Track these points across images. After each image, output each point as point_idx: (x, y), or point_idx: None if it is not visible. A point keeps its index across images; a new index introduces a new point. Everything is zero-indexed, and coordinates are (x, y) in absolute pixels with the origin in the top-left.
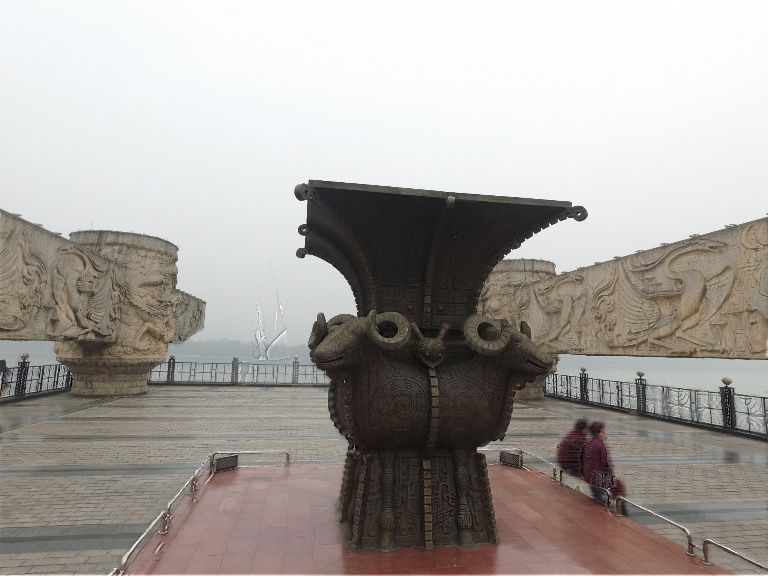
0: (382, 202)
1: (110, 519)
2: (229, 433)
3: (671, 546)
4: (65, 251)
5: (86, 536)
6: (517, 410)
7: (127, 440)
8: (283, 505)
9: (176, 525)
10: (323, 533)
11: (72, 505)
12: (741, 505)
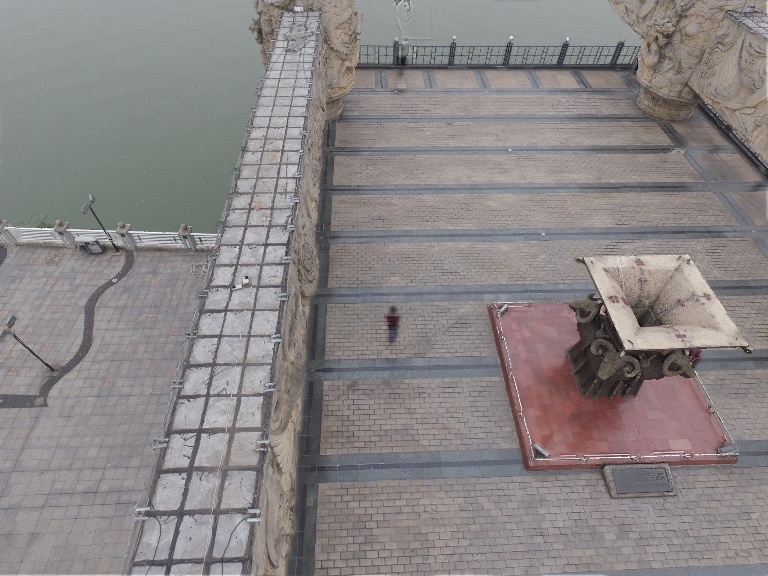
0: None
1: (474, 352)
2: (463, 227)
3: (703, 401)
4: None
5: (475, 366)
6: (661, 158)
7: (412, 242)
8: (545, 356)
9: (512, 371)
10: (569, 382)
11: (449, 337)
12: (757, 354)
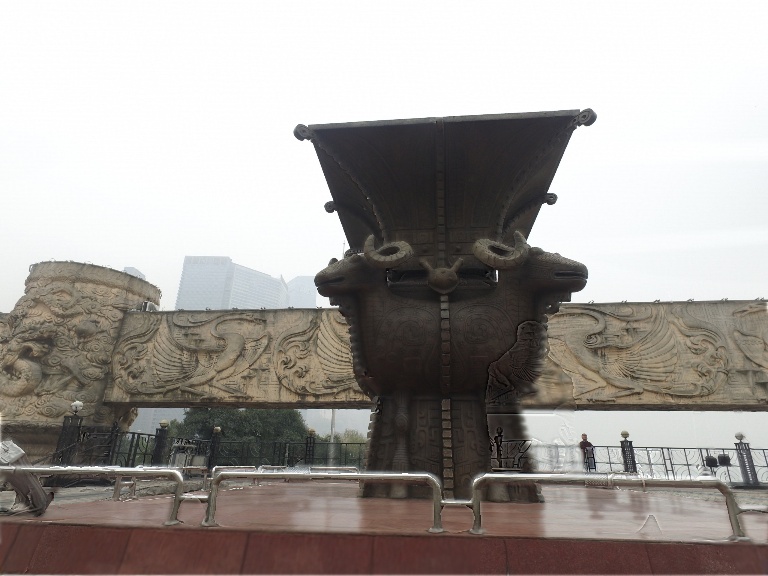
0: (352, 230)
1: None
2: None
3: None
4: (745, 312)
5: None
6: None
7: None
8: None
9: None
10: None
11: None
12: None
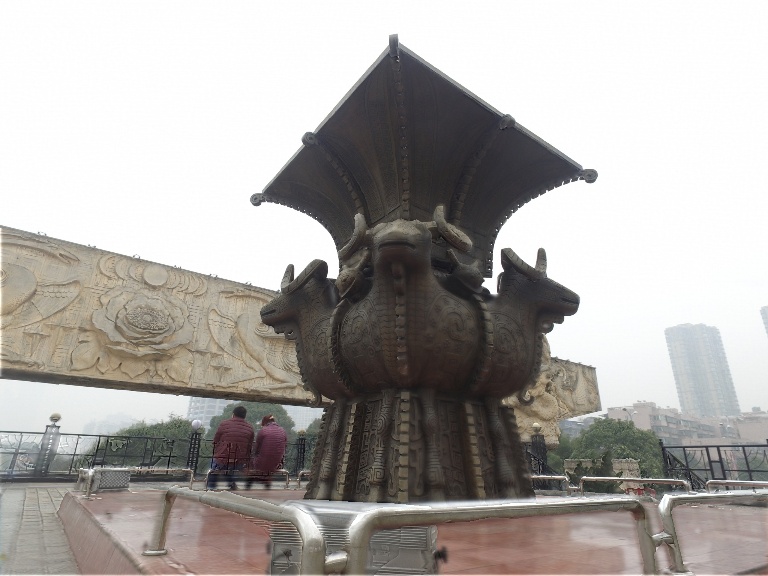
0: None
1: None
2: None
3: None
4: None
5: None
6: None
7: None
8: None
9: (763, 550)
10: None
11: None
12: None
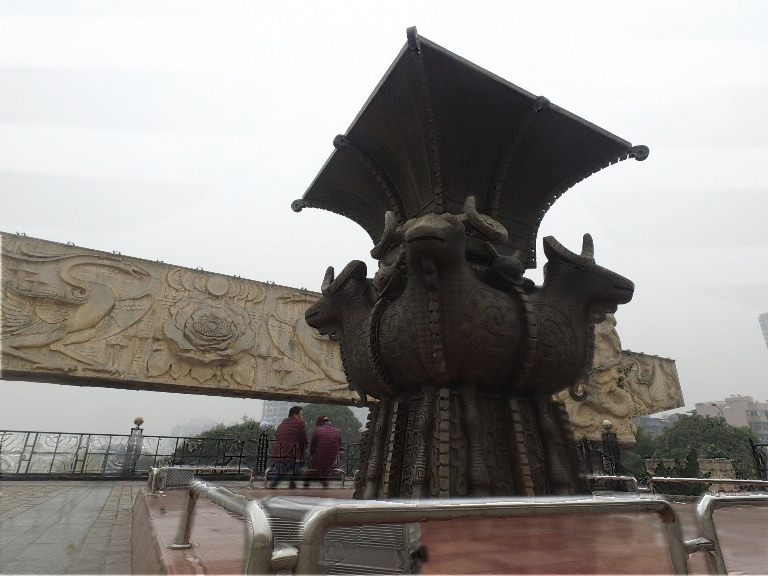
0: None
1: None
2: None
3: None
4: None
5: None
6: None
7: None
8: None
9: None
10: None
11: None
12: None
